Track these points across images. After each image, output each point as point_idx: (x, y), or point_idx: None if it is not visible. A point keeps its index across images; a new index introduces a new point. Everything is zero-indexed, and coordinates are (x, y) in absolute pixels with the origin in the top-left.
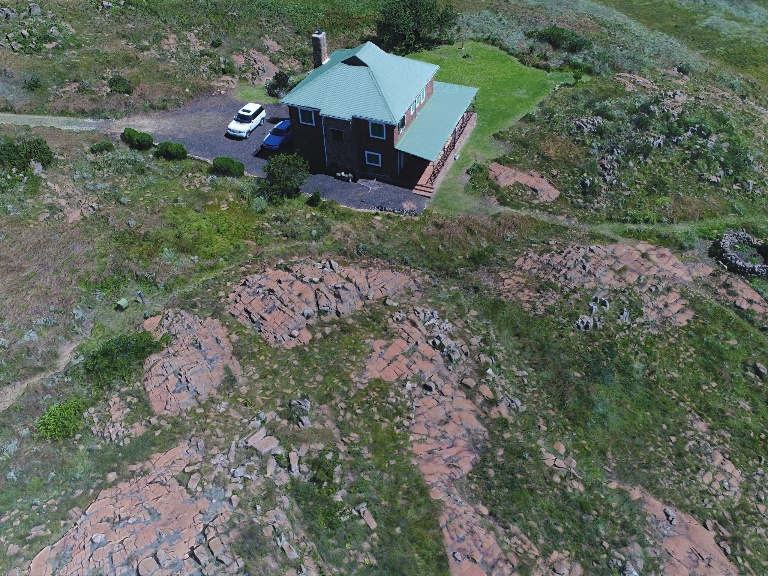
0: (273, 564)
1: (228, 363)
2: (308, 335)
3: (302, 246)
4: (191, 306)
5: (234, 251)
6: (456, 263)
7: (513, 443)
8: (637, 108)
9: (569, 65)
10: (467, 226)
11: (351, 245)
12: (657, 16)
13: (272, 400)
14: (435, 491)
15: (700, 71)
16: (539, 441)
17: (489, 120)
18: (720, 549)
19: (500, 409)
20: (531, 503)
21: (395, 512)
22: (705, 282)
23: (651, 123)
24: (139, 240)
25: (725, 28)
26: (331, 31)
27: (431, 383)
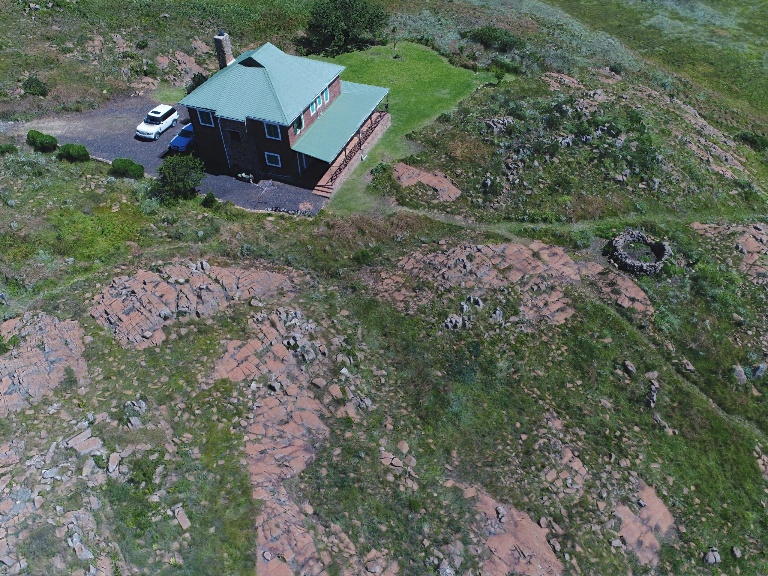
0: (60, 564)
1: (72, 364)
2: (161, 336)
3: (185, 247)
4: (54, 308)
5: (113, 252)
6: (340, 263)
7: (352, 442)
8: (551, 107)
9: (496, 65)
10: (359, 226)
11: (235, 246)
12: (602, 15)
13: (107, 401)
14: (258, 490)
15: (634, 70)
16: (381, 440)
17: (405, 120)
18: (549, 546)
19: (347, 408)
20: (358, 502)
21: (212, 512)
22: (592, 280)
23: (561, 122)
24: (18, 242)
25: (668, 27)
26: (265, 32)
27: (275, 383)
